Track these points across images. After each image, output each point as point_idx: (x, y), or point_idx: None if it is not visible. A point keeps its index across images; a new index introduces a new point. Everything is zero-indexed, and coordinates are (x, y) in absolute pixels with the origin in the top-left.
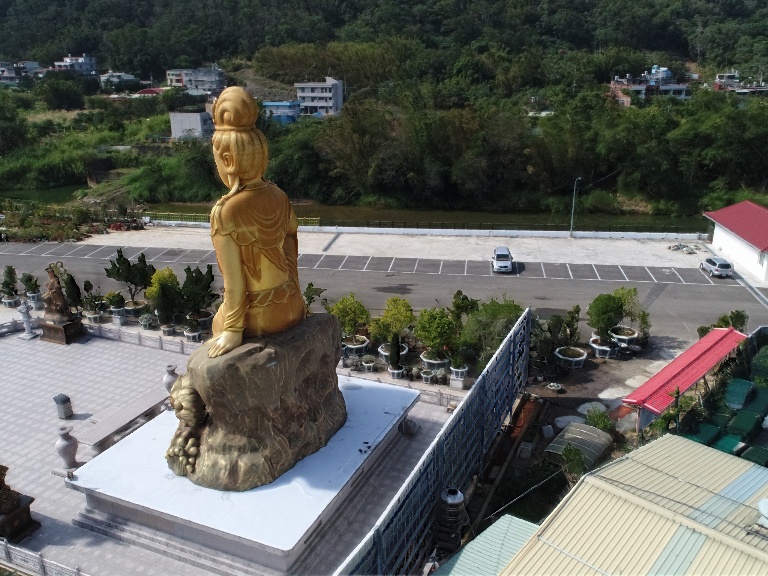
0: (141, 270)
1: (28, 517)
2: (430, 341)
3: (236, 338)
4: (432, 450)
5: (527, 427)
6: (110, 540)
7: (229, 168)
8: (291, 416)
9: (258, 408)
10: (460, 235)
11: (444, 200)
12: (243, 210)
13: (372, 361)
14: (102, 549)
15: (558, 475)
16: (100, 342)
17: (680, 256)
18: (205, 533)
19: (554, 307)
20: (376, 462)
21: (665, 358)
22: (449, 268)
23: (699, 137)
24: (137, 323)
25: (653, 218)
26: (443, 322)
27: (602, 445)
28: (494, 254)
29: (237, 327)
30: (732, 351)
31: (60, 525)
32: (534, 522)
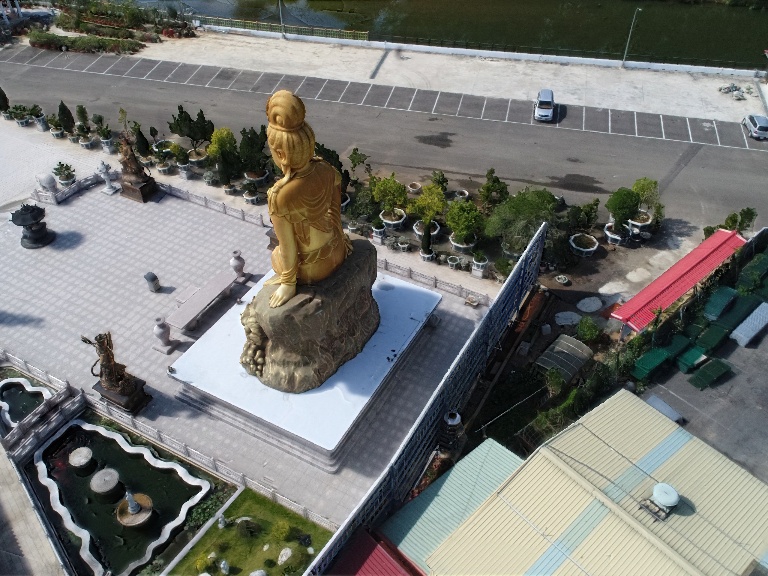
0: (201, 128)
1: (143, 393)
2: (458, 231)
3: (291, 290)
4: (439, 389)
5: (530, 324)
6: (204, 415)
7: (282, 160)
8: (334, 338)
9: (309, 339)
10: (509, 58)
11: None
12: (295, 197)
13: (407, 243)
14: (199, 422)
15: (543, 383)
16: (172, 201)
17: (727, 103)
18: None
19: (583, 174)
20: (401, 359)
21: (670, 248)
22: (491, 111)
23: None
24: (201, 177)
25: (729, 9)
26: (471, 216)
27: (583, 360)
28: (537, 98)
29: (292, 282)
30: (726, 260)
31: (166, 398)
32: (517, 421)
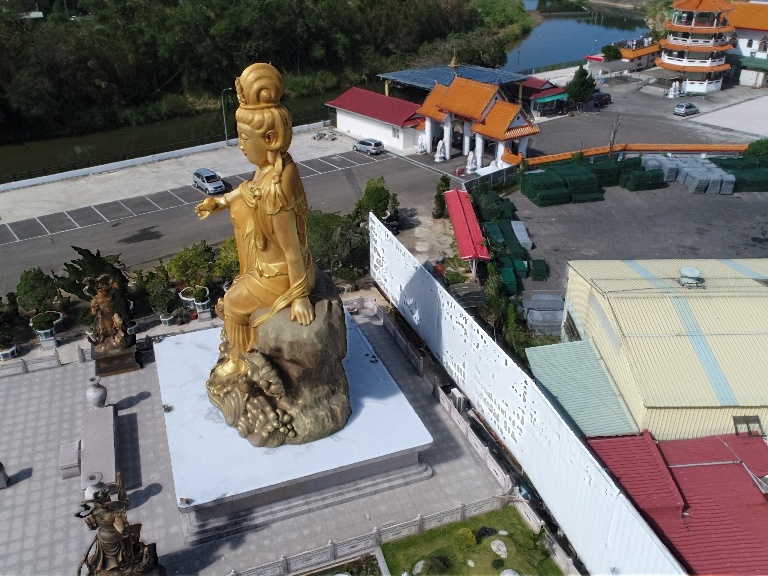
0: None
1: None
2: None
3: (309, 302)
4: None
5: (406, 304)
6: (247, 534)
7: (271, 145)
8: None
9: None
10: (124, 167)
11: (6, 133)
12: (295, 182)
13: None
14: (252, 543)
15: None
16: None
17: (329, 143)
18: (342, 473)
19: None
20: None
21: (417, 225)
22: (163, 202)
23: (240, 31)
24: None
25: None
26: None
27: None
28: (199, 177)
29: (306, 292)
30: None
31: (181, 555)
32: None
